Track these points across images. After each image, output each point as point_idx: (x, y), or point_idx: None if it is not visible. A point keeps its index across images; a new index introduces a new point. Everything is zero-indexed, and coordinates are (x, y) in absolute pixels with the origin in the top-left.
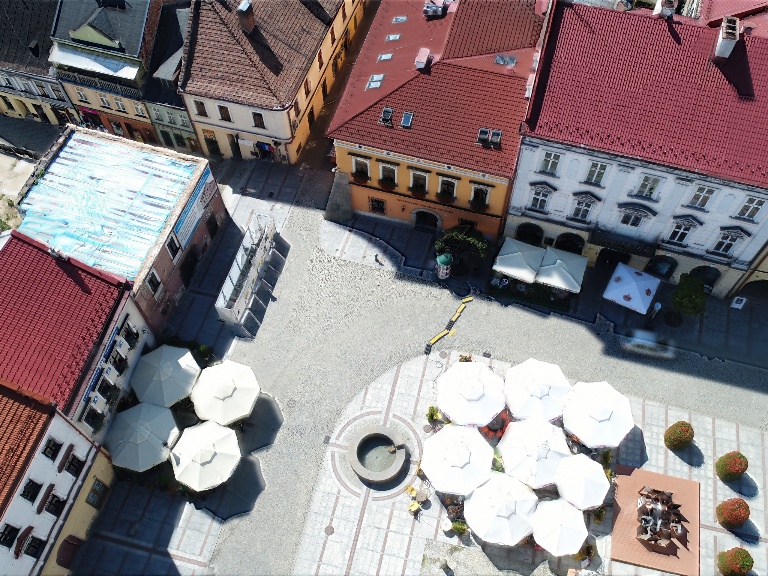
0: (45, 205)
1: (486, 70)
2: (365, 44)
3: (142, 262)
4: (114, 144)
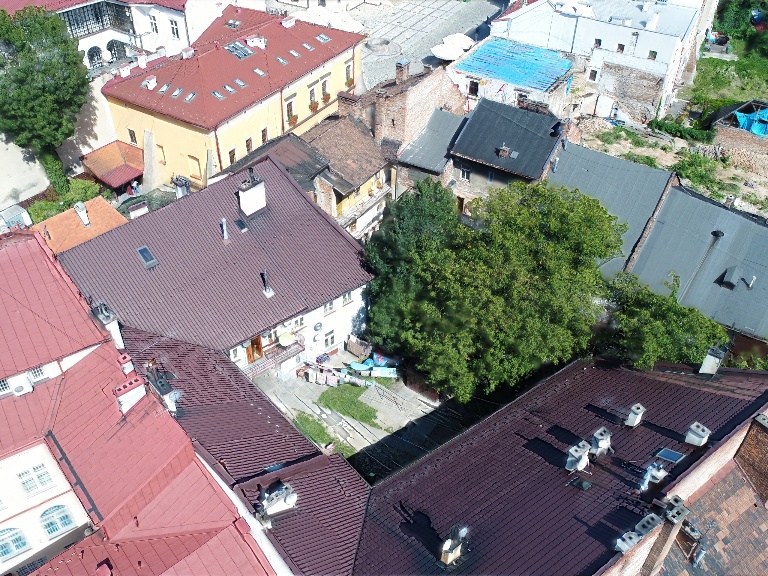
0: (553, 67)
1: None
2: (316, 65)
3: None
4: (513, 83)
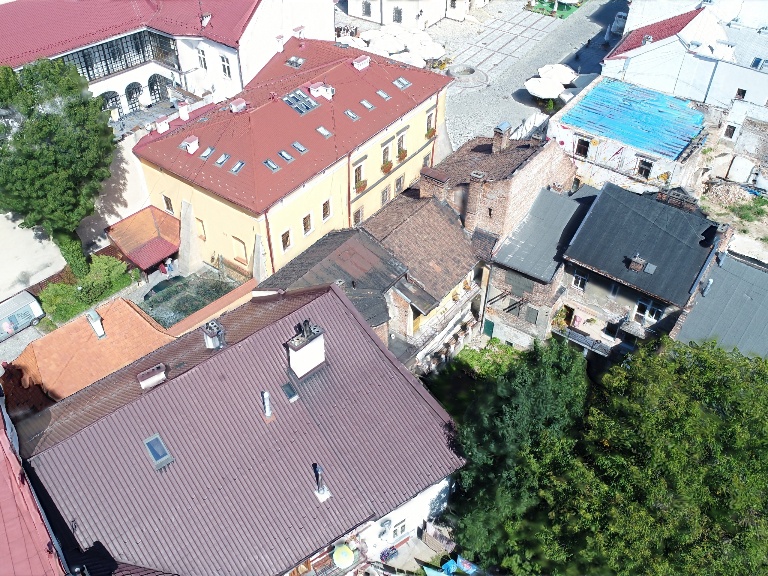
0: (682, 123)
1: (321, 47)
2: (392, 120)
3: (598, 86)
4: (634, 146)
